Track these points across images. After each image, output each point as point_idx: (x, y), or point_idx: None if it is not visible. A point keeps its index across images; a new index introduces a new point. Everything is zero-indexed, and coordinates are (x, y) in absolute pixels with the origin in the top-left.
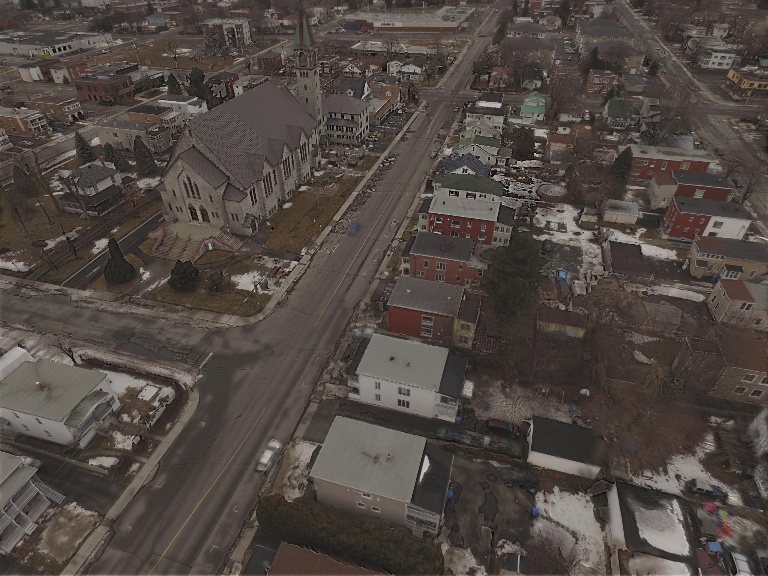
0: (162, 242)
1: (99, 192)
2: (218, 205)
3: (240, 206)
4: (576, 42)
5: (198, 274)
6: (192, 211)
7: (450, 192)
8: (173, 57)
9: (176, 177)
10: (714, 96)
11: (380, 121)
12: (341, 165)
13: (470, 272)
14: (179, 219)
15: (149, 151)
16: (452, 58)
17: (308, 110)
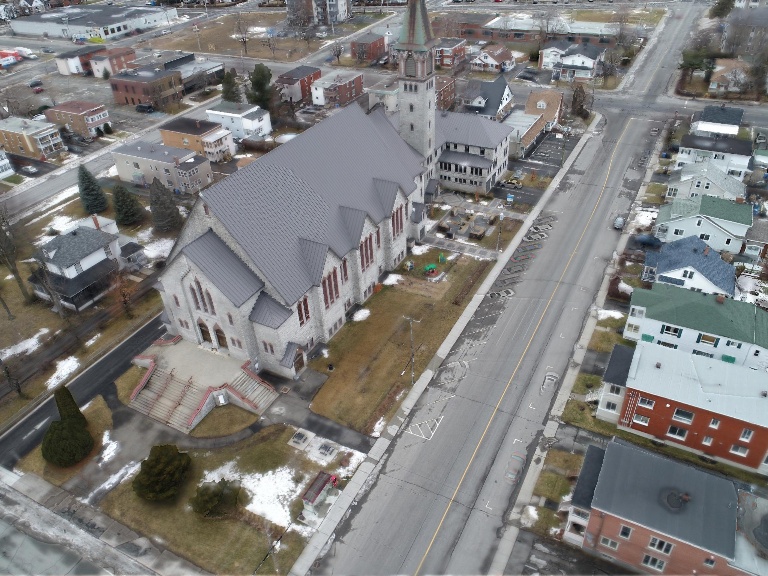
0: (148, 382)
1: (83, 272)
2: (241, 330)
3: (277, 334)
4: None
5: (190, 462)
6: (203, 329)
7: (664, 327)
8: (242, 41)
9: (179, 279)
10: None
11: (525, 150)
12: (458, 234)
13: (731, 575)
14: (184, 337)
15: (178, 191)
16: (641, 39)
17: (412, 142)
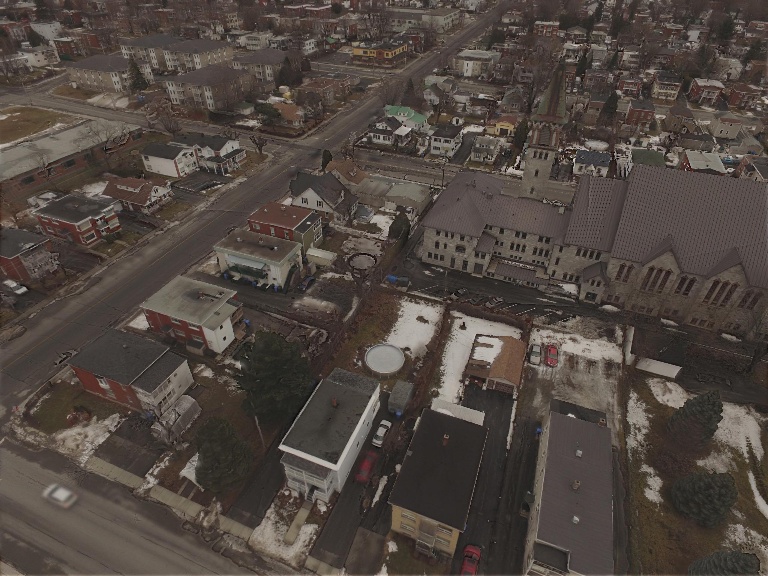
0: None
1: None
2: None
3: None
4: (165, 66)
5: None
6: None
7: None
8: None
9: None
10: (379, 70)
11: None
12: None
13: None
14: None
15: None
16: None
17: None
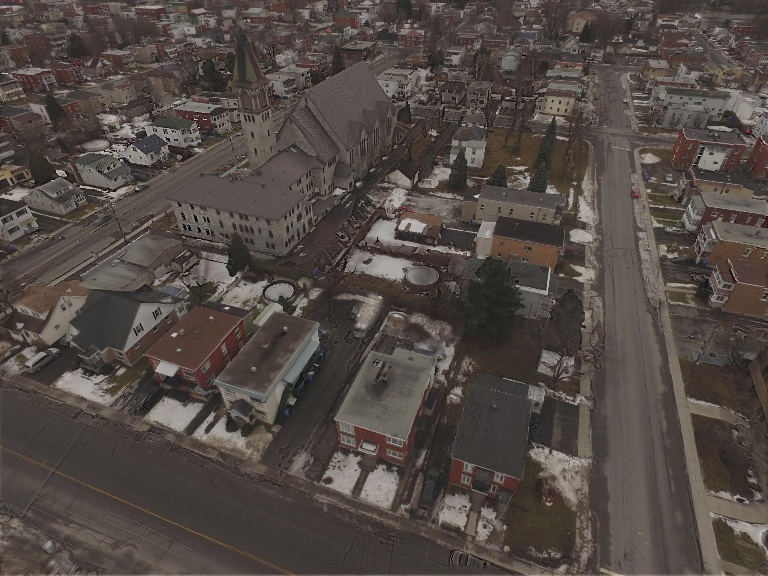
0: None
1: None
2: None
3: None
4: None
5: None
6: None
7: None
8: None
9: None
10: None
11: None
12: None
13: None
14: None
15: None
16: None
17: None
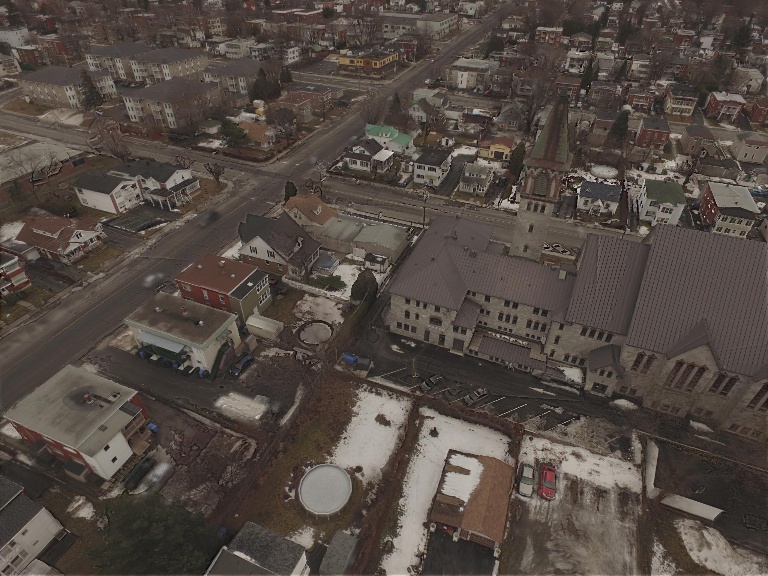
0: None
1: None
2: None
3: None
4: (132, 77)
5: None
6: None
7: None
8: None
9: None
10: (366, 81)
11: None
12: None
13: None
14: None
15: None
16: None
17: None
